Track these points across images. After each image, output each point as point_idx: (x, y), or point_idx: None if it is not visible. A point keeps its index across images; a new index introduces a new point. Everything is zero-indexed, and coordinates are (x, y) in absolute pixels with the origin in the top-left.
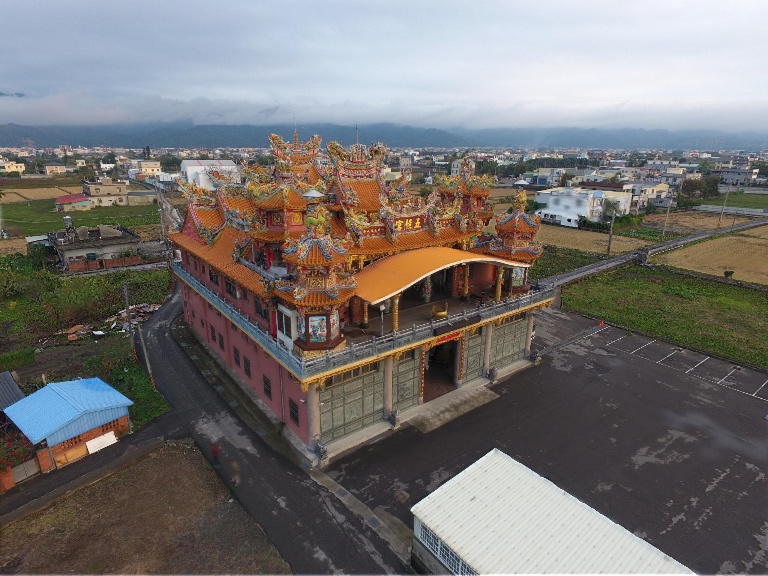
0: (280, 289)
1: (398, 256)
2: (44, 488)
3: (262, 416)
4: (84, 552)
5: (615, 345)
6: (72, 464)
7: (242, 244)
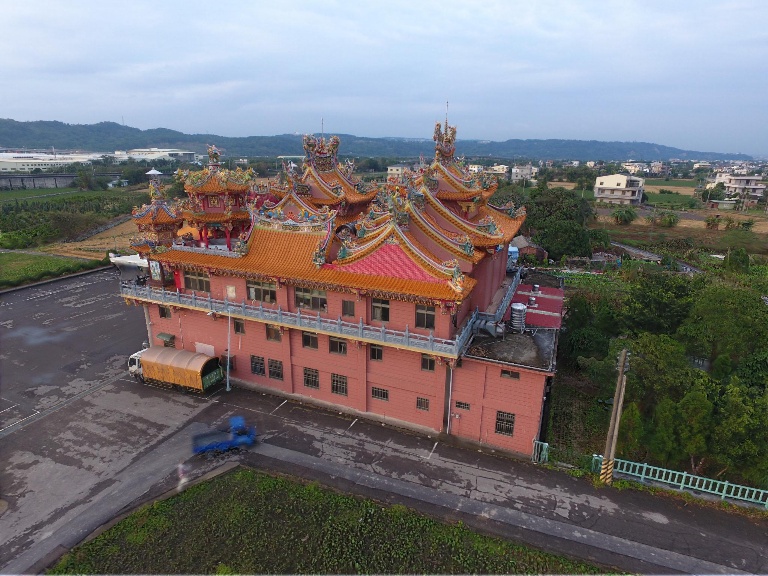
0: None
1: None
2: None
3: None
4: None
5: (3, 407)
6: None
7: None
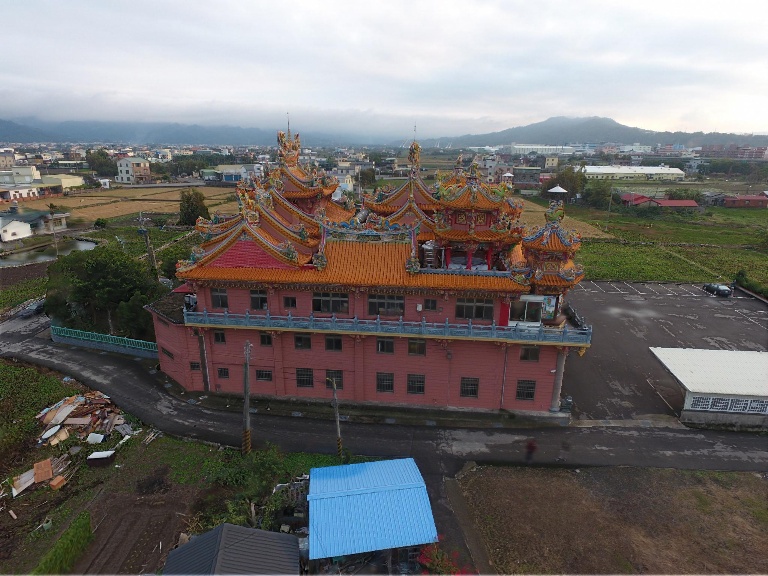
0: (538, 279)
1: None
2: None
3: (473, 416)
4: (600, 569)
5: None
6: None
7: None
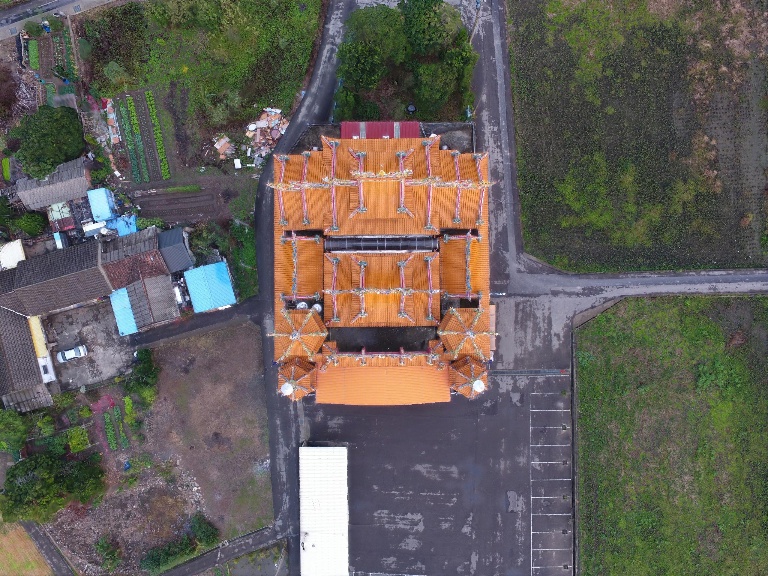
0: None
1: (361, 369)
2: (202, 323)
3: None
4: (213, 369)
5: (535, 397)
6: (213, 313)
7: (286, 297)
